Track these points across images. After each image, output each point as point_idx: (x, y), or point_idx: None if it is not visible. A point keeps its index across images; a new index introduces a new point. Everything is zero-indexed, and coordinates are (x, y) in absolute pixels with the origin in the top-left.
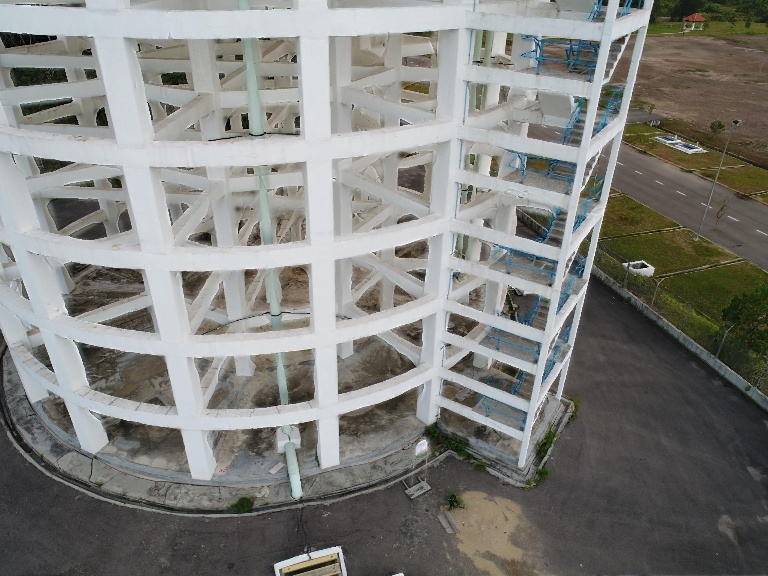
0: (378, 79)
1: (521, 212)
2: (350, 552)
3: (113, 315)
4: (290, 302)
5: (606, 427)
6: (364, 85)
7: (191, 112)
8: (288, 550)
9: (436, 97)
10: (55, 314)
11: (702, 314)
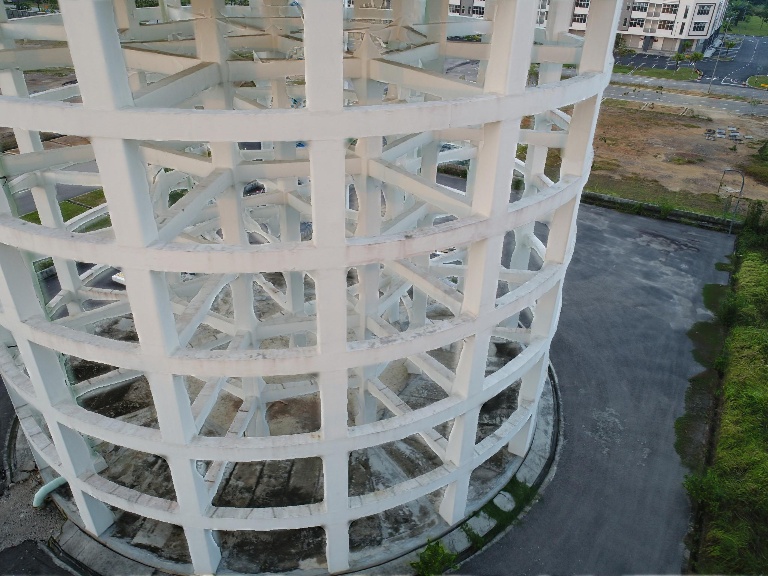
0: None
1: None
2: None
3: None
4: None
5: None
6: None
7: None
8: None
9: None
10: None
11: None
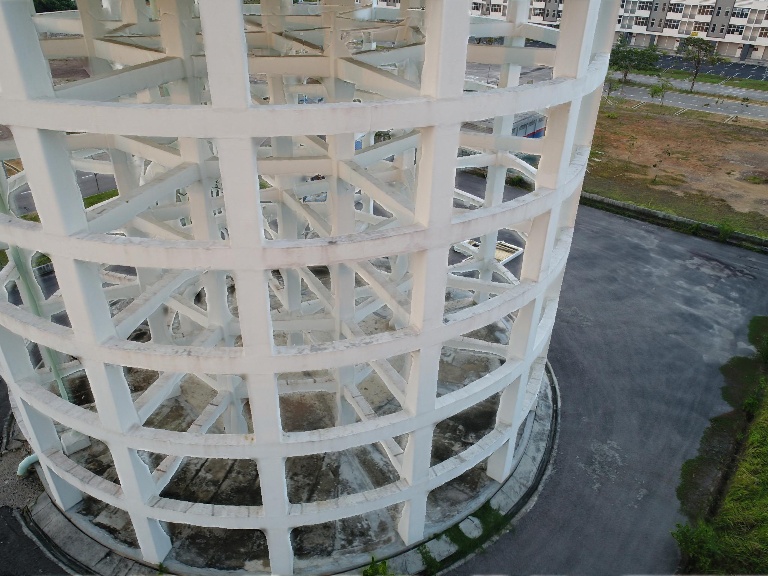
0: None
1: None
2: (459, 261)
3: None
4: None
5: None
6: None
7: None
8: (478, 273)
9: (71, 153)
10: None
11: None
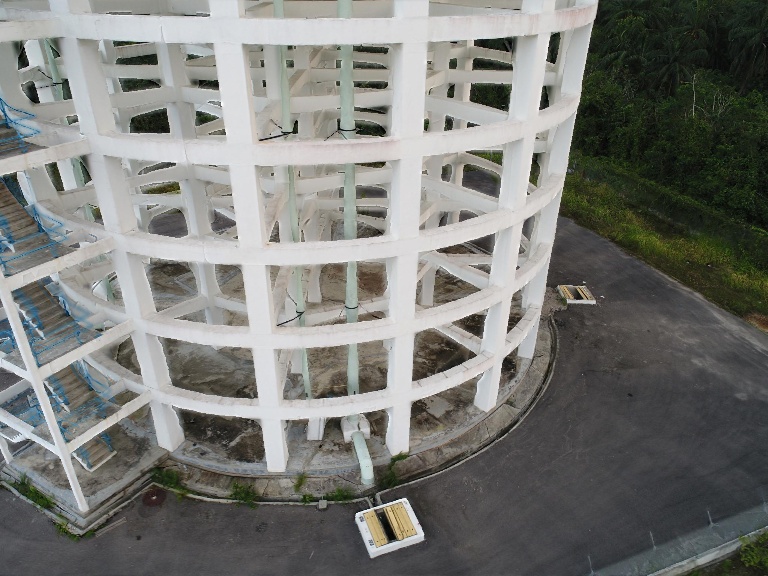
0: None
1: None
2: None
3: (229, 216)
4: (311, 307)
5: (30, 568)
6: (210, 97)
7: (115, 68)
8: None
9: (498, 200)
10: (124, 166)
11: None
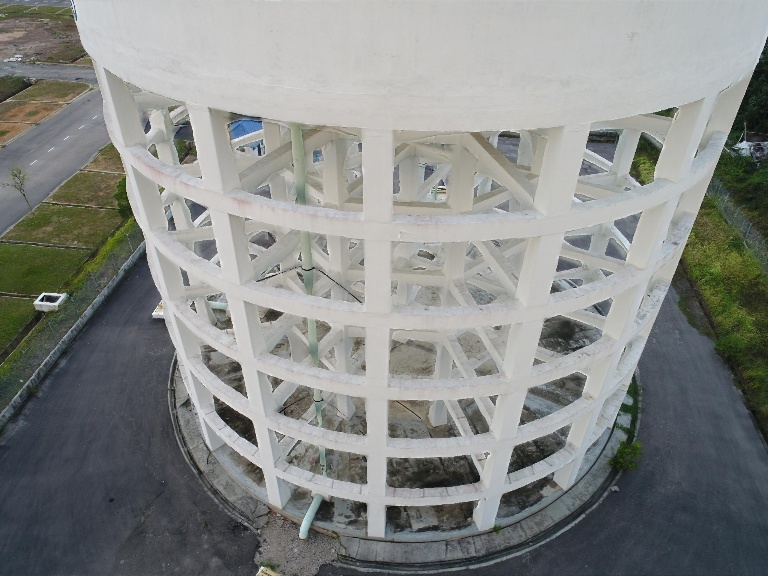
0: None
1: (9, 408)
2: None
3: None
4: None
5: None
6: None
7: None
8: None
9: None
10: None
11: (86, 261)
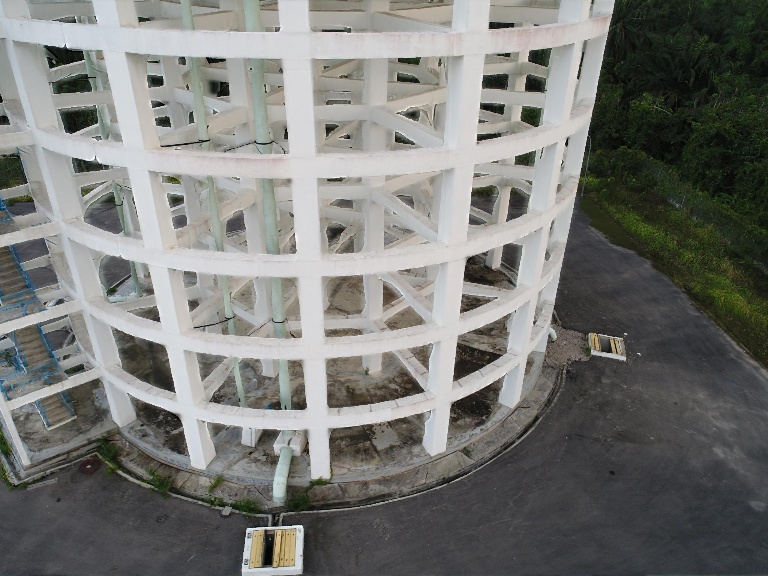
0: (211, 103)
1: None
2: None
3: None
4: None
5: None
6: None
7: (151, 66)
8: None
9: (438, 232)
10: None
11: None
